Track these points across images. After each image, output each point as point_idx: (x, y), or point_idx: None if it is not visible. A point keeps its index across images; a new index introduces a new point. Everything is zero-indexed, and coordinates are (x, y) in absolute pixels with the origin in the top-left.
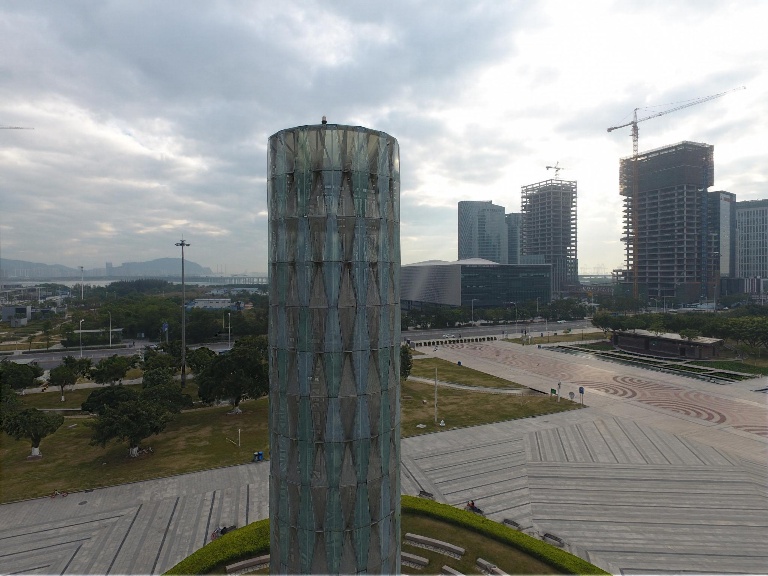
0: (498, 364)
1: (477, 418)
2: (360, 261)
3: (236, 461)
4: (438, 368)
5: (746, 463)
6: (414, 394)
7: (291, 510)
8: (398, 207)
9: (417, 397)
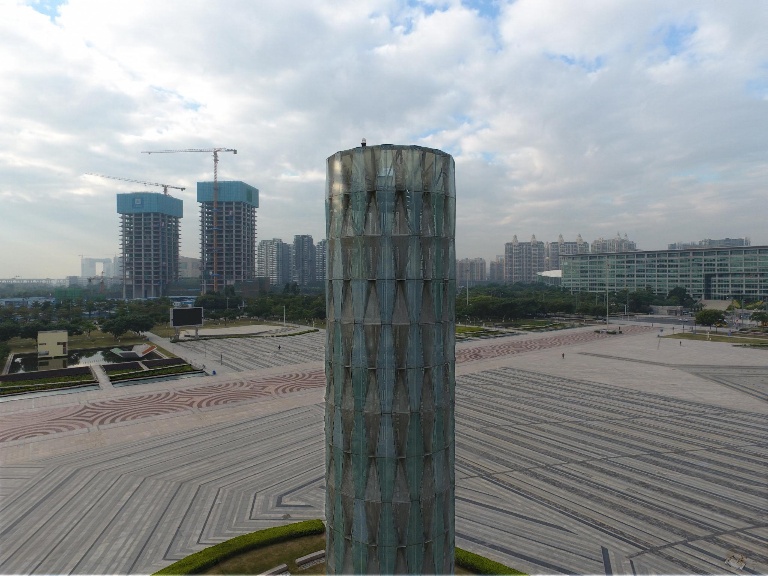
0: None
1: None
2: None
3: None
4: None
5: (46, 461)
6: None
7: None
8: None
9: None
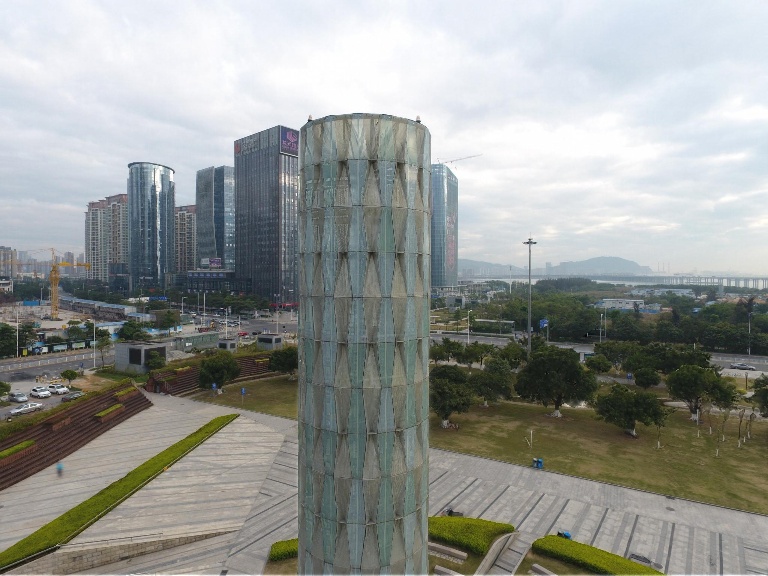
0: None
1: None
2: (332, 251)
3: (516, 460)
4: None
5: None
6: None
7: None
8: (405, 189)
9: None
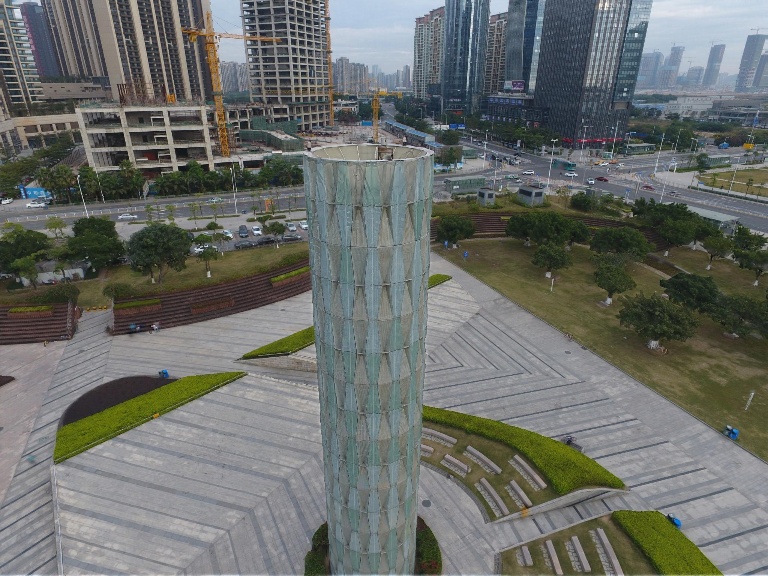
0: None
1: None
2: None
3: (708, 417)
4: None
5: None
6: None
7: None
8: (365, 230)
9: None
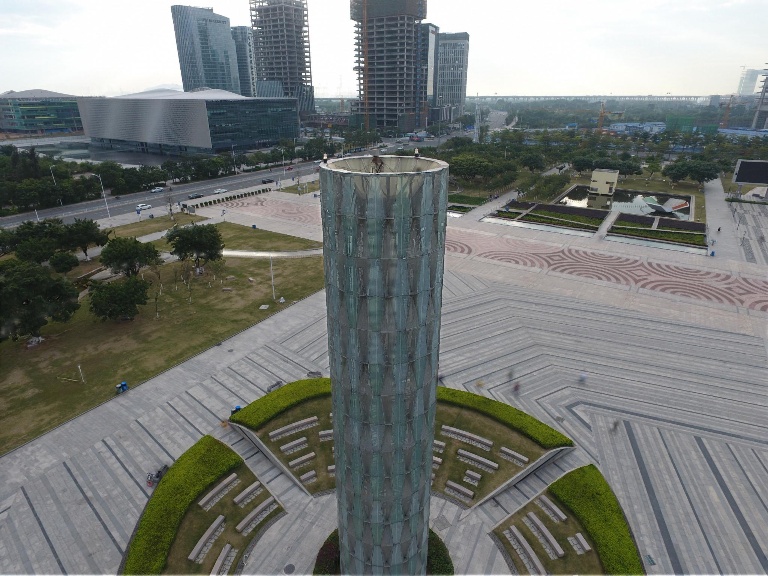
0: (290, 221)
1: (307, 287)
2: None
3: (97, 400)
4: (236, 235)
5: (494, 284)
6: (233, 272)
7: (384, 468)
8: None
9: (239, 275)
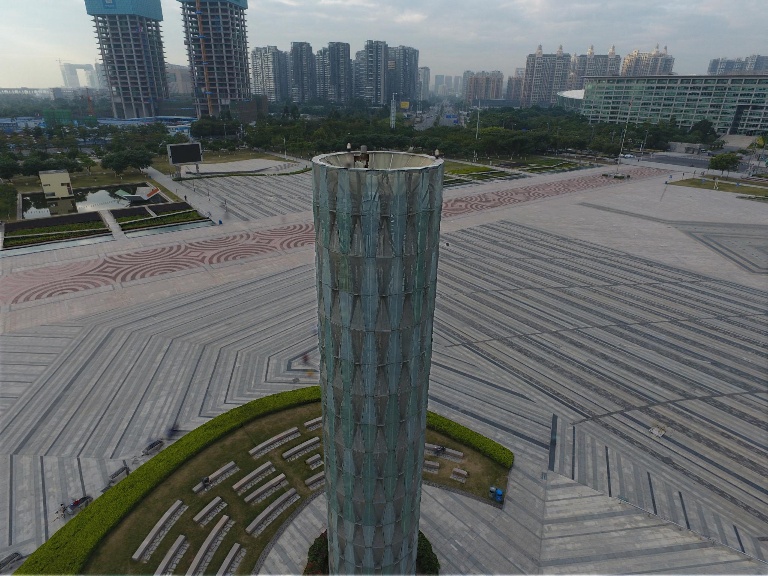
0: None
1: None
2: None
3: None
4: None
5: (83, 321)
6: None
7: None
8: None
9: None
